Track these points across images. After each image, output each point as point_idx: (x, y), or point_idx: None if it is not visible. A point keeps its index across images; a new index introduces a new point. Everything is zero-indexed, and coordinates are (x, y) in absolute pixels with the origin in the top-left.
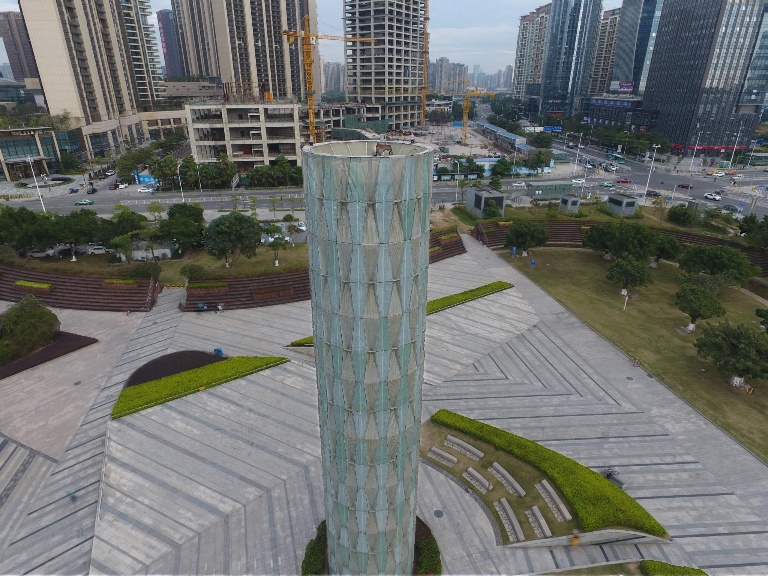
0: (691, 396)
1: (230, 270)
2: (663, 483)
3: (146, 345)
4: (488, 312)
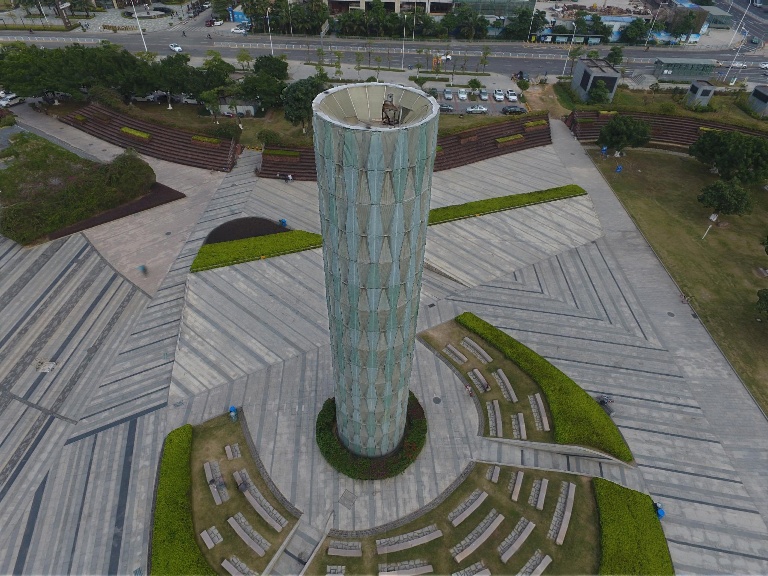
0: (729, 344)
1: (303, 140)
2: (653, 419)
3: (224, 206)
4: (548, 220)
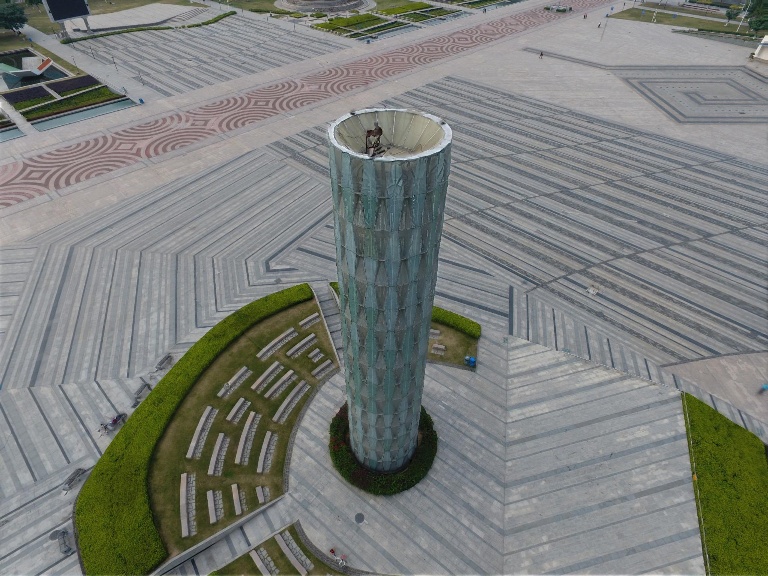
0: None
1: None
2: None
3: None
4: None
